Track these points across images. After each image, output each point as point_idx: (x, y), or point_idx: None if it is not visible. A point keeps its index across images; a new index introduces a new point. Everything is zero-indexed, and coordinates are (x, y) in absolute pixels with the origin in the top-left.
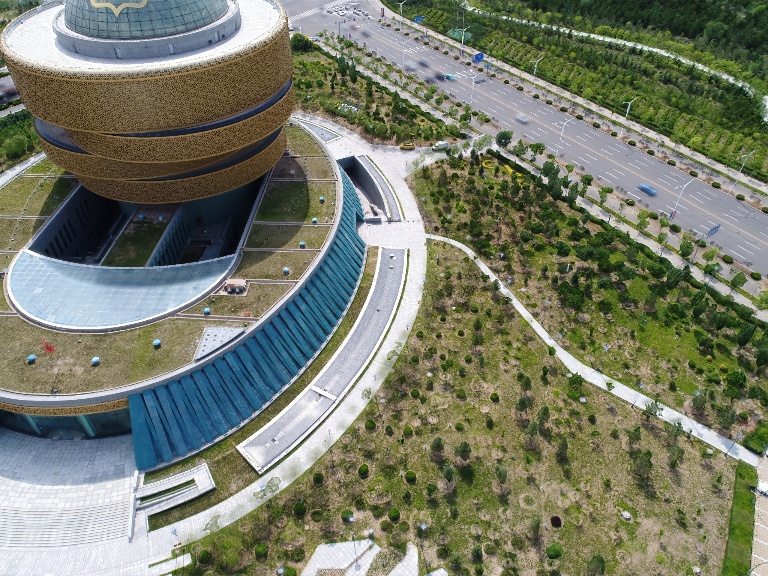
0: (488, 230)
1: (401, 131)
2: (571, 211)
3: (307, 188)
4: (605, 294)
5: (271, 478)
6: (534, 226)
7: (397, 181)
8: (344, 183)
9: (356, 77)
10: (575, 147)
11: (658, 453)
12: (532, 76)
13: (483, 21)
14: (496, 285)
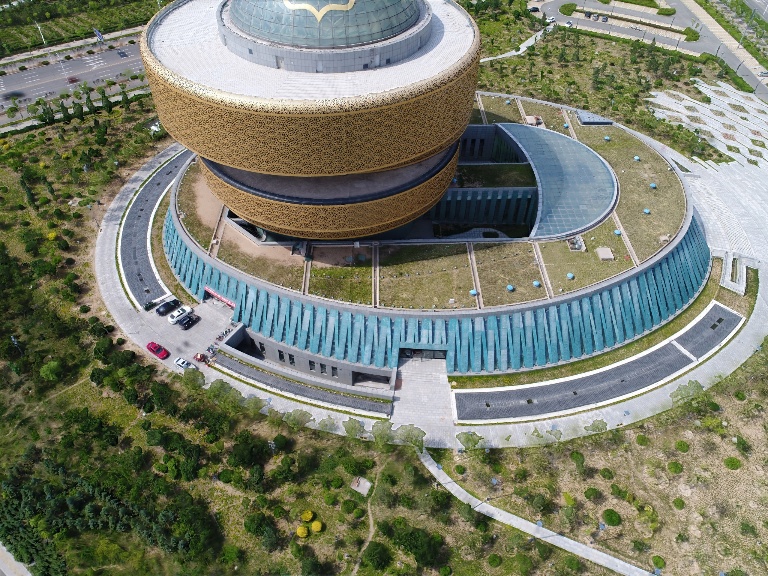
0: None
1: None
2: None
3: None
4: None
5: (648, 121)
6: None
7: None
8: None
9: None
10: None
11: None
12: (124, 31)
13: None
14: None
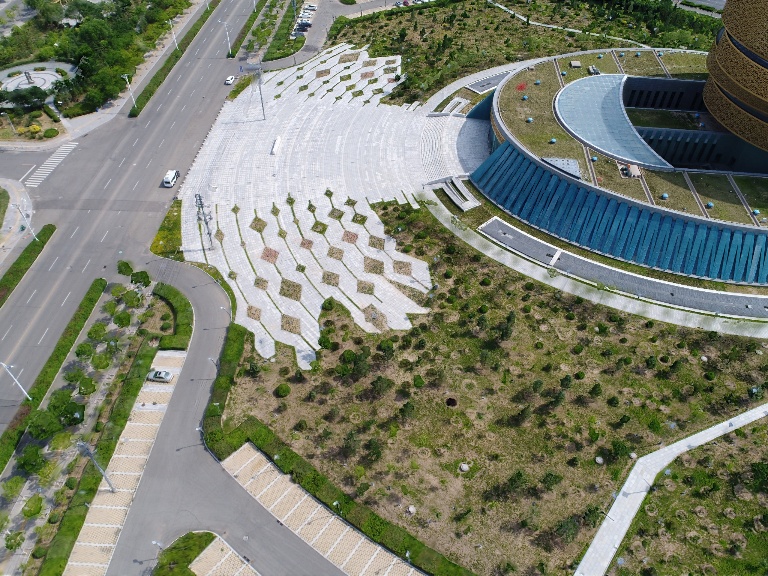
0: None
1: None
2: None
3: None
4: None
5: None
6: None
7: None
8: None
9: None
10: None
11: (539, 517)
12: None
13: None
14: None
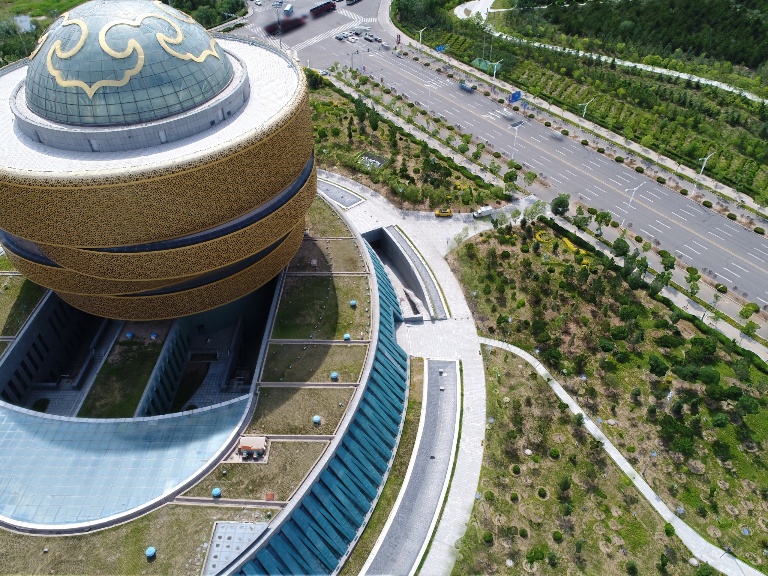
0: (555, 331)
1: (437, 196)
2: (652, 302)
3: (333, 286)
4: (719, 431)
5: None
6: (616, 331)
7: (436, 261)
8: (377, 274)
9: (377, 124)
10: (641, 211)
11: None
12: (576, 116)
13: (513, 49)
14: (580, 420)
